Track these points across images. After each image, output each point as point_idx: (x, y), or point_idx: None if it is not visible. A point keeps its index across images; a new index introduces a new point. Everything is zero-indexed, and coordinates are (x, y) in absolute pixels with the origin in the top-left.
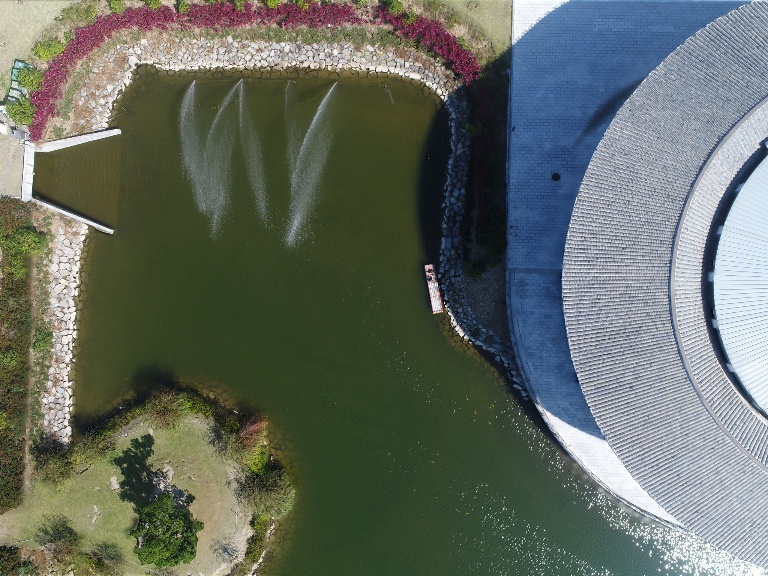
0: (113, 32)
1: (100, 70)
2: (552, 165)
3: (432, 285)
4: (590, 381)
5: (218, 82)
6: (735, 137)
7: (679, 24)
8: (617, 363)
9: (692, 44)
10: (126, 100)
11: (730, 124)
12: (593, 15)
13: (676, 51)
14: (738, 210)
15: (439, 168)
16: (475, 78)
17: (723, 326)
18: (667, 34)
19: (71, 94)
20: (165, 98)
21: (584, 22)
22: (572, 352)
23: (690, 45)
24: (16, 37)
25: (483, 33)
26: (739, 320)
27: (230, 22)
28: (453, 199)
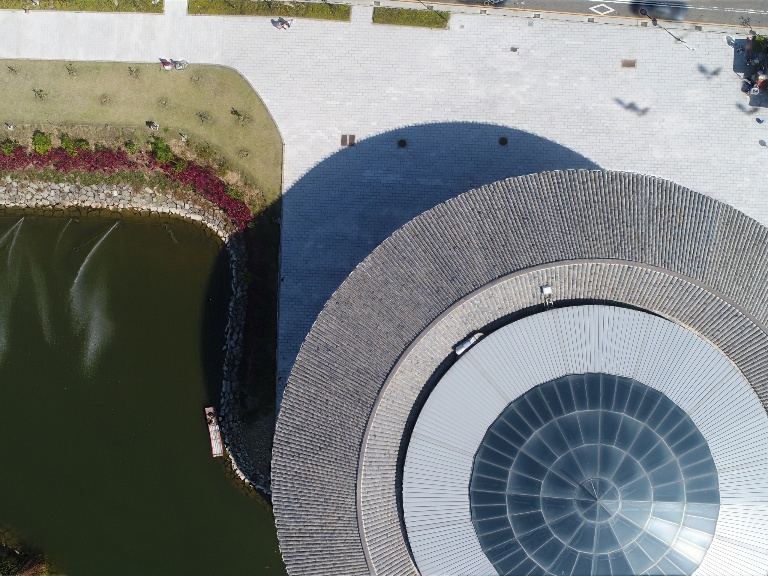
0: None
1: None
2: None
3: (213, 428)
4: (297, 575)
5: (2, 219)
6: (422, 344)
7: (447, 177)
8: (318, 561)
9: (398, 237)
10: None
11: (417, 331)
12: (362, 166)
13: (383, 243)
14: (426, 417)
15: (221, 309)
16: (247, 226)
17: (411, 534)
18: (435, 187)
19: None
20: None
21: (353, 173)
22: (281, 544)
23: (397, 238)
24: None
25: (254, 182)
26: (427, 528)
27: (3, 165)
28: (232, 343)
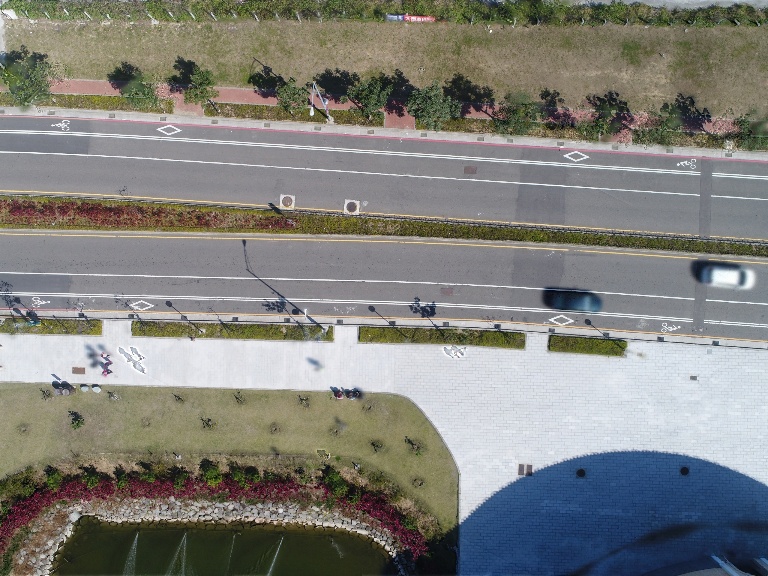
0: (51, 503)
1: (40, 529)
2: None
3: None
4: None
5: (162, 532)
6: None
7: (628, 507)
8: None
9: None
10: (68, 549)
11: None
12: (541, 496)
13: None
14: None
15: None
16: (422, 553)
17: None
18: (616, 517)
19: (10, 555)
20: (108, 546)
21: (532, 503)
22: None
23: None
24: None
25: (429, 511)
26: None
27: (171, 493)
28: None
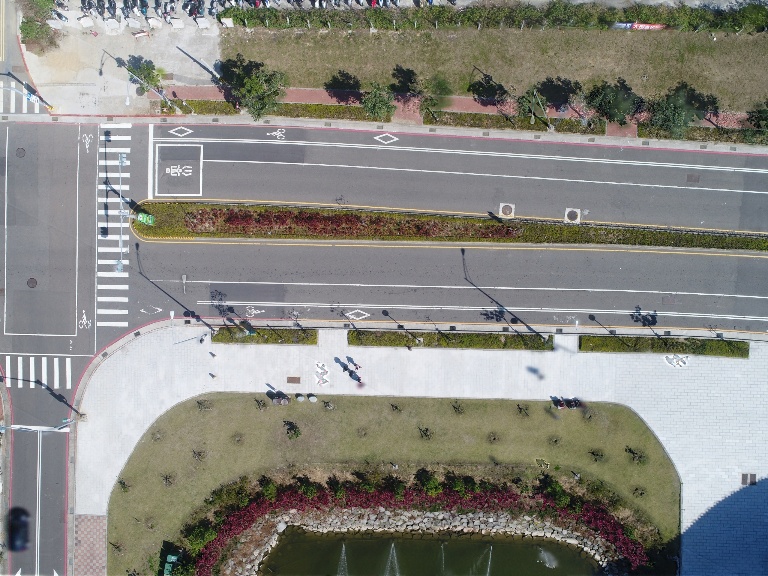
0: None
1: (248, 539)
2: None
3: None
4: None
5: (367, 541)
6: None
7: None
8: None
9: None
10: (272, 559)
11: None
12: (764, 506)
13: None
14: None
15: None
16: (641, 563)
17: None
18: None
19: (218, 565)
20: (311, 556)
21: (755, 513)
22: None
23: None
24: (164, 518)
25: (650, 520)
26: None
27: (386, 503)
28: None
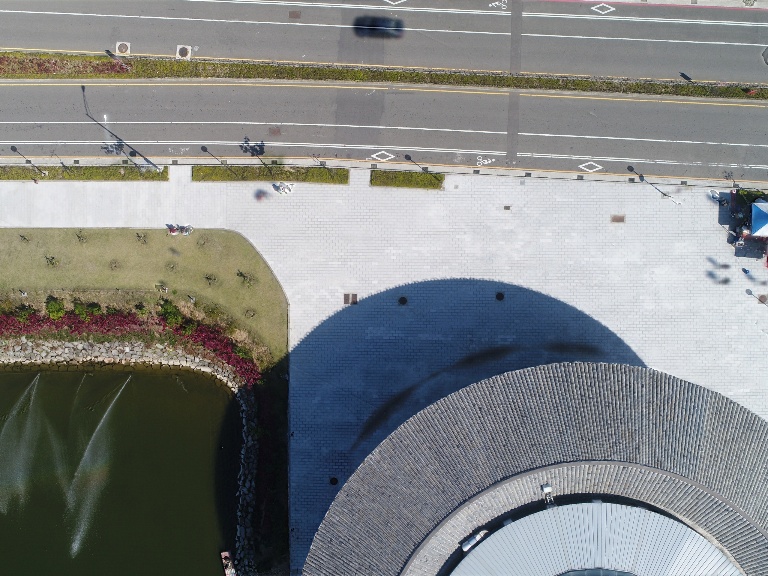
0: None
1: None
2: (330, 469)
3: (229, 571)
4: None
5: (18, 374)
6: (430, 544)
7: (447, 332)
8: None
9: (404, 432)
10: None
11: (425, 532)
12: (365, 324)
13: (390, 437)
14: None
15: (233, 456)
16: (256, 382)
17: None
18: (436, 342)
19: None
20: None
21: (357, 330)
22: None
23: (402, 432)
24: None
25: (261, 340)
26: None
27: (19, 330)
28: (245, 490)
